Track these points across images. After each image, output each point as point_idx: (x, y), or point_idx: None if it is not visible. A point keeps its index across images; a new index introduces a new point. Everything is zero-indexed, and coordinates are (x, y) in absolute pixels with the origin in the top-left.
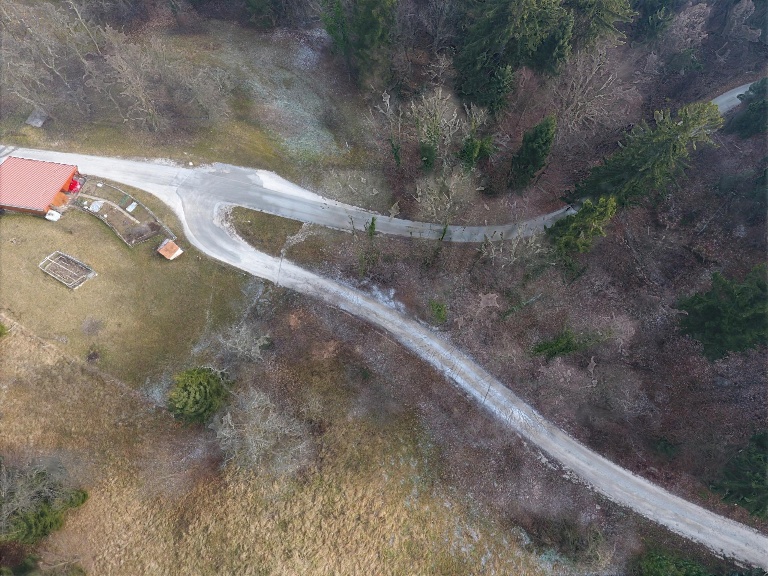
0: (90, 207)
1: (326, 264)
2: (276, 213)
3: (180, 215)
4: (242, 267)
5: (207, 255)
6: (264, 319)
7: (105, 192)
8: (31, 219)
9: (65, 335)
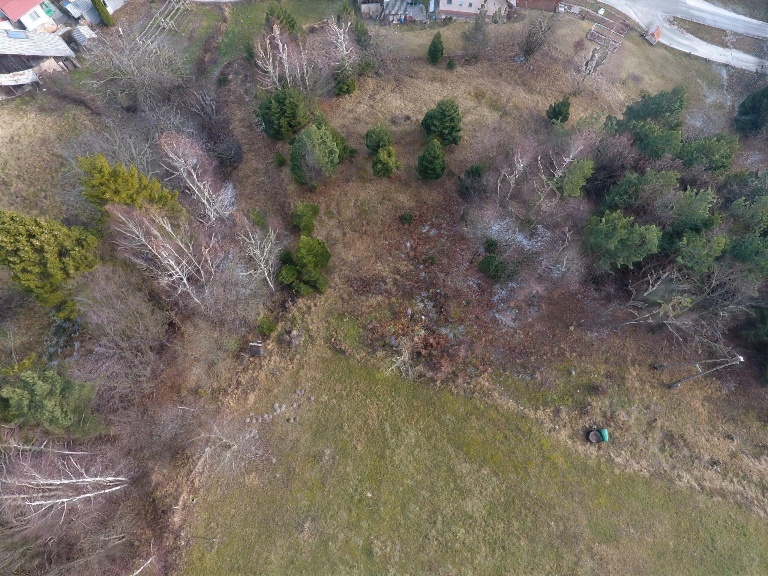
0: (571, 10)
1: (765, 54)
2: (703, 23)
3: (636, 20)
4: (701, 55)
5: (671, 46)
6: (741, 86)
7: (576, 1)
8: (545, 11)
9: (623, 81)
